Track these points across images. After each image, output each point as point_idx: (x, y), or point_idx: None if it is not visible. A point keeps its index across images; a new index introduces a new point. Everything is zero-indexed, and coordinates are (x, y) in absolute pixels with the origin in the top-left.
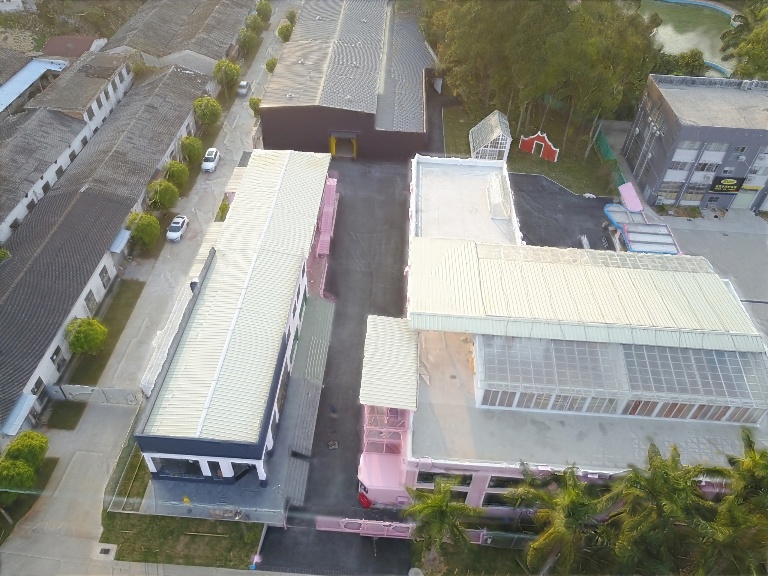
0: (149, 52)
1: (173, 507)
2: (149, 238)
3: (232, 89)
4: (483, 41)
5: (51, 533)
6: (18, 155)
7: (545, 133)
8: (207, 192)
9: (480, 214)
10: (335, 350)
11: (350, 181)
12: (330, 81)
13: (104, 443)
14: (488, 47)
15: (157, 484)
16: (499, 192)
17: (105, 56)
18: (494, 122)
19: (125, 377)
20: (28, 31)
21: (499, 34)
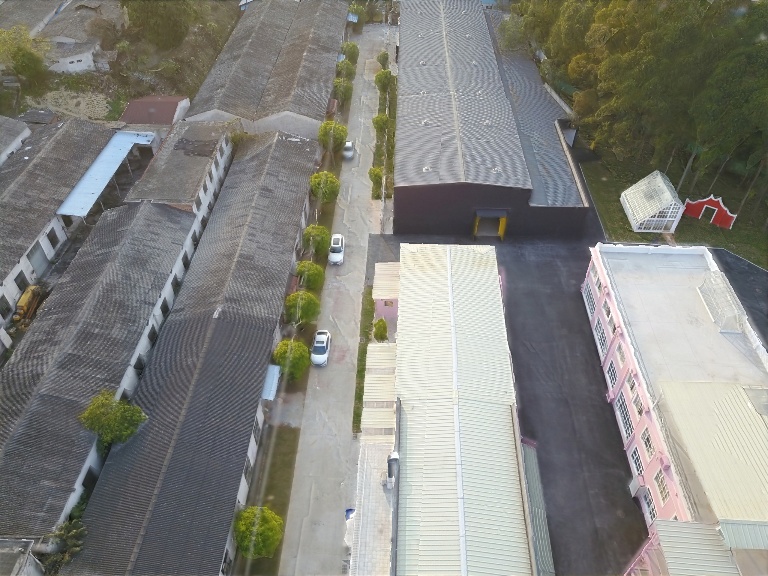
0: (242, 115)
1: None
2: (300, 372)
3: (337, 152)
4: (656, 97)
5: None
6: (130, 269)
7: (720, 197)
8: (341, 293)
9: (703, 326)
10: (556, 522)
11: (504, 269)
12: (467, 148)
13: None
14: (663, 104)
15: None
16: (729, 300)
17: (200, 126)
18: (658, 186)
19: None
20: (101, 94)
21: (677, 88)
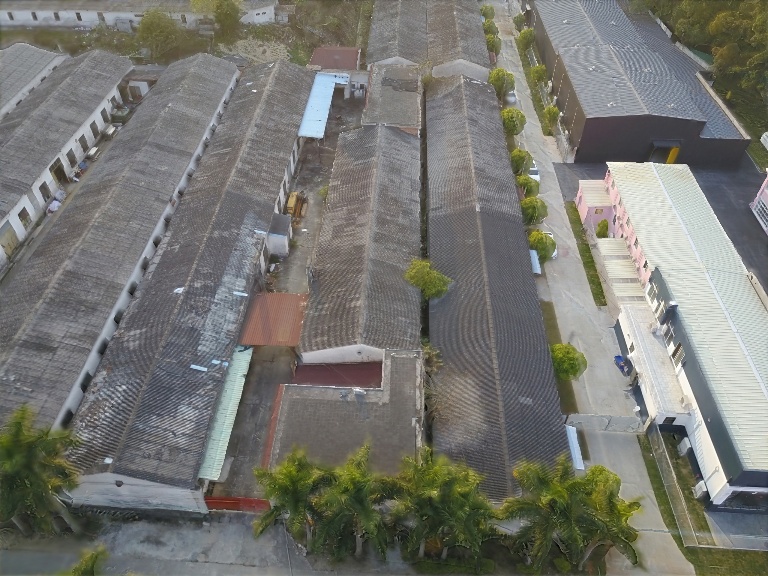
0: (419, 62)
1: (748, 540)
2: (550, 257)
3: None
4: None
5: (645, 570)
6: (391, 174)
7: None
8: None
9: None
10: None
11: None
12: (640, 88)
13: (629, 473)
14: None
15: (715, 516)
16: None
17: (396, 68)
18: None
19: (601, 403)
20: (282, 43)
21: None
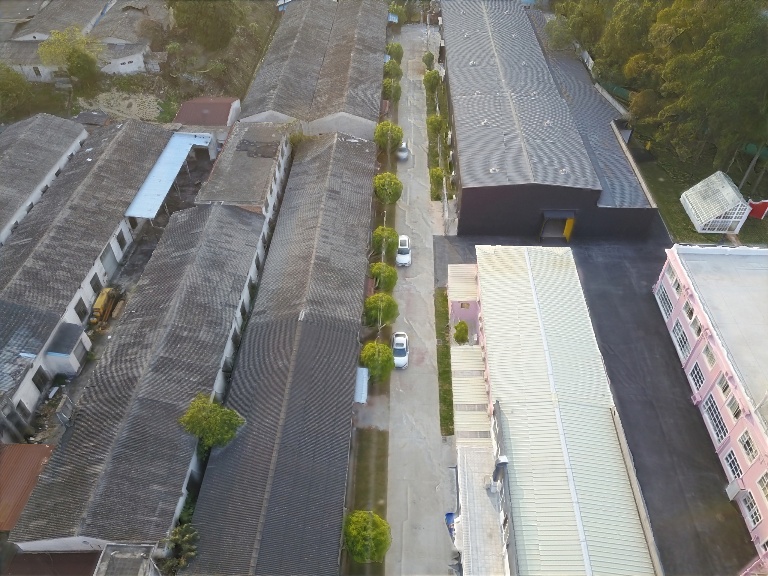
0: (297, 116)
1: None
2: (387, 375)
3: (392, 153)
4: (726, 97)
5: None
6: (209, 271)
7: None
8: (413, 294)
9: None
10: (656, 526)
11: None
12: (532, 148)
13: None
14: (733, 104)
15: None
16: None
17: (259, 127)
18: (722, 186)
19: None
20: (152, 95)
21: (748, 88)
